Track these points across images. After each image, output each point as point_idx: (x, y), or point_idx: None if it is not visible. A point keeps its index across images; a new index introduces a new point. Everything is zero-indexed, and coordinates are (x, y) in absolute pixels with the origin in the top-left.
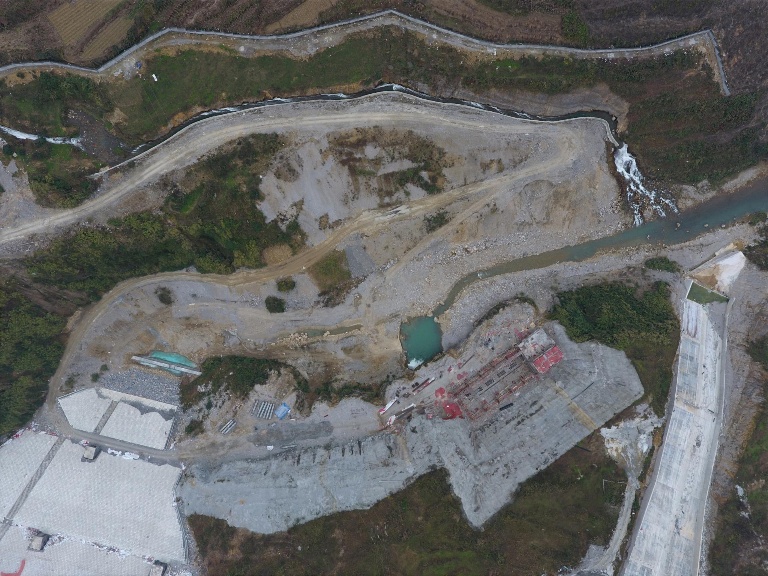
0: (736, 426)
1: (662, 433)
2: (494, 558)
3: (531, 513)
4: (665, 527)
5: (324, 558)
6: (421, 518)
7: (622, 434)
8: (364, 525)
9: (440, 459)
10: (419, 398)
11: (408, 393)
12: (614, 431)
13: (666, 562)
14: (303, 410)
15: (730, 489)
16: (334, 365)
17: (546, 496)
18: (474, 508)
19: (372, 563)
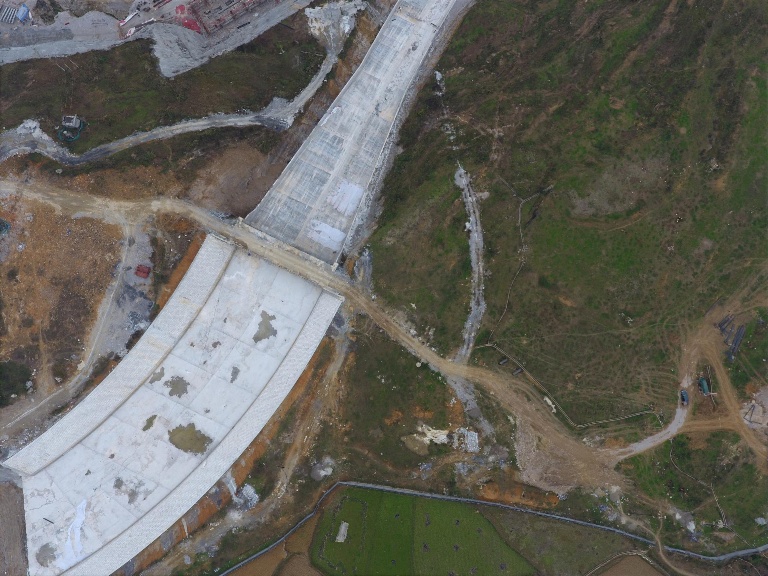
0: (449, 29)
1: (377, 33)
2: (174, 95)
3: (223, 71)
4: (365, 108)
5: (10, 85)
6: (117, 70)
7: (325, 14)
8: (57, 67)
9: (151, 35)
10: (160, 13)
11: (148, 7)
12: (318, 11)
13: (359, 135)
14: (48, 22)
15: (430, 75)
16: (97, 4)
17: (241, 60)
18: (173, 70)
19: (55, 91)
